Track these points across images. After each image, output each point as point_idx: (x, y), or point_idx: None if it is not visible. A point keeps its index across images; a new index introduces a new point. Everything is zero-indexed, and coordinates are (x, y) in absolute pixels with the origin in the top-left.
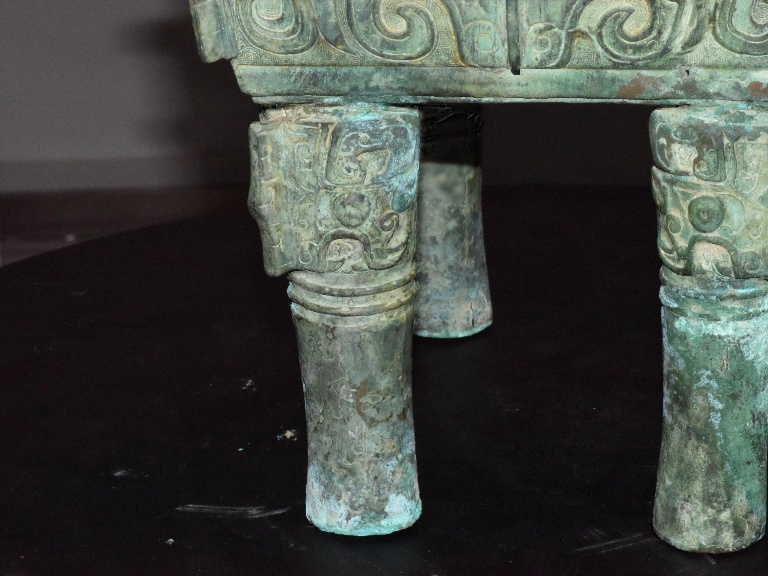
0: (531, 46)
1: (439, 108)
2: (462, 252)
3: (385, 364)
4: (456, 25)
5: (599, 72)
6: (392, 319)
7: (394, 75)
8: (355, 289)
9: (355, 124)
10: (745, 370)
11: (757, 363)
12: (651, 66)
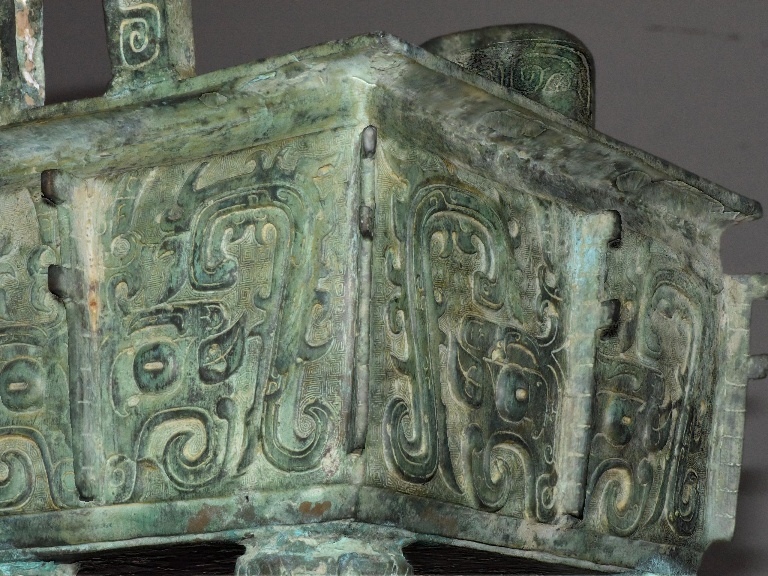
0: (108, 480)
1: None
2: None
3: None
4: (46, 465)
5: (170, 505)
6: None
7: (3, 527)
8: None
9: None
10: None
11: None
12: (212, 492)
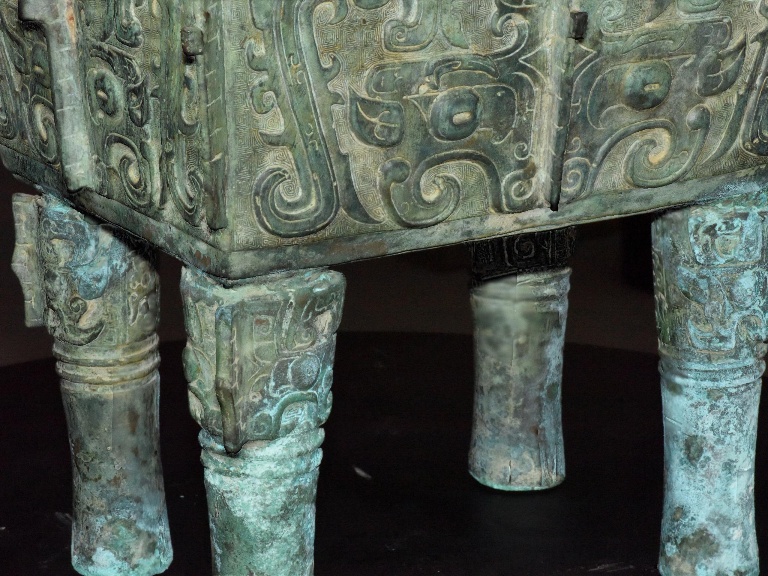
0: None
1: (485, 266)
2: (506, 410)
3: (92, 430)
4: None
5: (131, 210)
6: (96, 393)
7: None
8: (62, 355)
9: (48, 211)
10: (235, 524)
11: (248, 523)
12: None
